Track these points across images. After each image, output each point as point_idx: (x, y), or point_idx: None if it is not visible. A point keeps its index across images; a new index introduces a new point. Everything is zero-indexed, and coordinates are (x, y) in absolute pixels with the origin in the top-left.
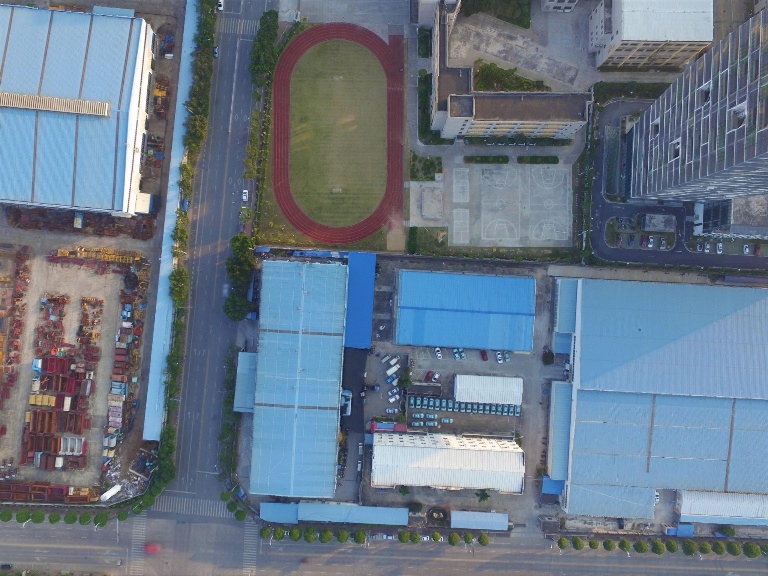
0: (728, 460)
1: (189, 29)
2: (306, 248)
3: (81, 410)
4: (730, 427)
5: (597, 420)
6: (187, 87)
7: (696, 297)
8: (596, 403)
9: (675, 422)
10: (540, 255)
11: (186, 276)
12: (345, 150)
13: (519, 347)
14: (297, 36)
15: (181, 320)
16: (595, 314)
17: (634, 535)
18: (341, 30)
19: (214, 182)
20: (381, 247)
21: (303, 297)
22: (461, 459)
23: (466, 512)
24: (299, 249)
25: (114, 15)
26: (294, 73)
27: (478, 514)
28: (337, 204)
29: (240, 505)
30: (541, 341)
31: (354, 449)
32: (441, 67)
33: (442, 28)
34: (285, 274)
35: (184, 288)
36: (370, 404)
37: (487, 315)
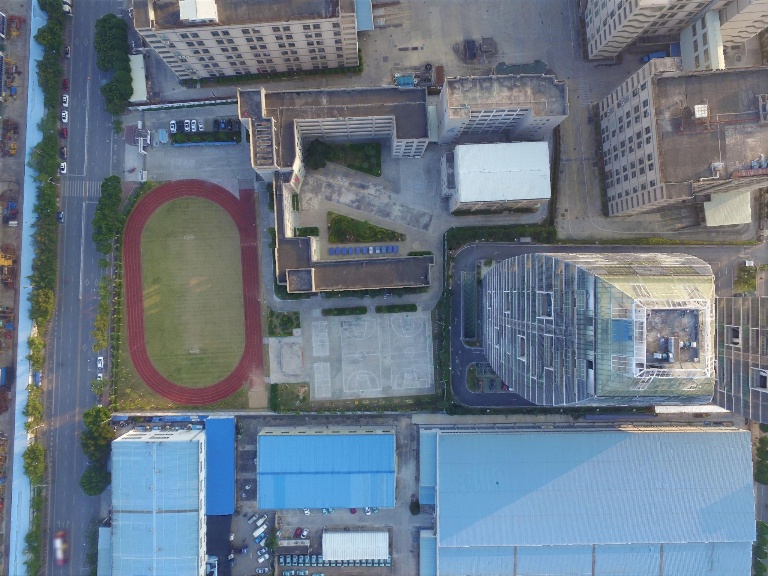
0: None
1: (29, 198)
2: (167, 411)
3: None
4: (591, 571)
5: (460, 574)
6: (30, 259)
7: (552, 446)
8: (458, 558)
9: (537, 570)
10: (403, 404)
11: (41, 453)
12: (201, 309)
13: (381, 504)
14: (145, 196)
15: (42, 494)
16: (453, 470)
17: None
18: (190, 187)
19: (68, 350)
20: (243, 405)
21: (155, 476)
22: None
23: None
24: (158, 415)
25: None
26: (144, 234)
27: None
28: (196, 365)
29: None
30: (408, 489)
31: None
32: (280, 238)
33: (279, 198)
34: (135, 454)
35: (38, 467)
36: (240, 564)
37: (347, 475)
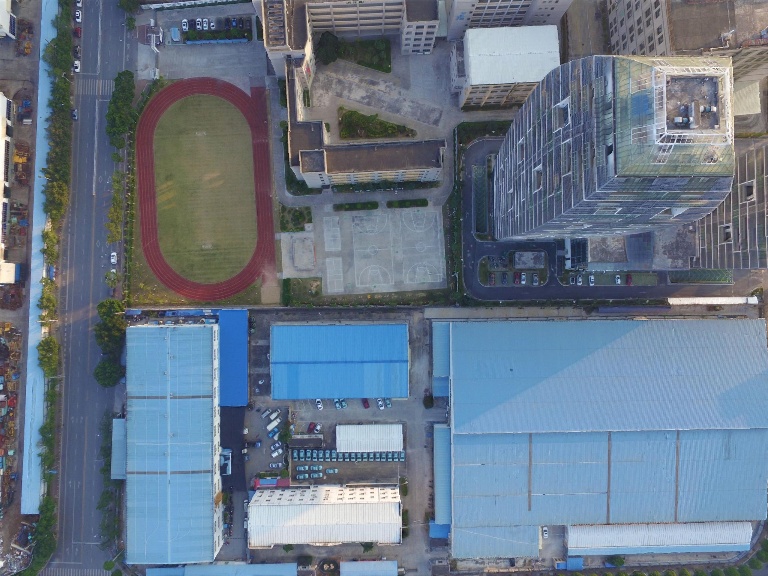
0: (608, 492)
1: (44, 94)
2: (180, 307)
3: None
4: (607, 460)
5: (475, 463)
6: (45, 153)
7: (566, 333)
8: (473, 446)
9: (553, 459)
10: (415, 298)
11: (55, 345)
12: (213, 205)
13: (395, 394)
14: (157, 93)
15: (55, 389)
16: (466, 357)
17: (525, 572)
18: (202, 85)
19: (82, 246)
20: (256, 301)
21: (169, 361)
22: (337, 514)
23: (355, 562)
24: (171, 309)
25: None
26: (157, 131)
27: (367, 563)
28: (208, 260)
29: (128, 572)
30: (422, 384)
31: (240, 506)
32: (292, 122)
33: (291, 83)
34: (149, 339)
35: (52, 358)
36: (254, 460)
37: (361, 365)
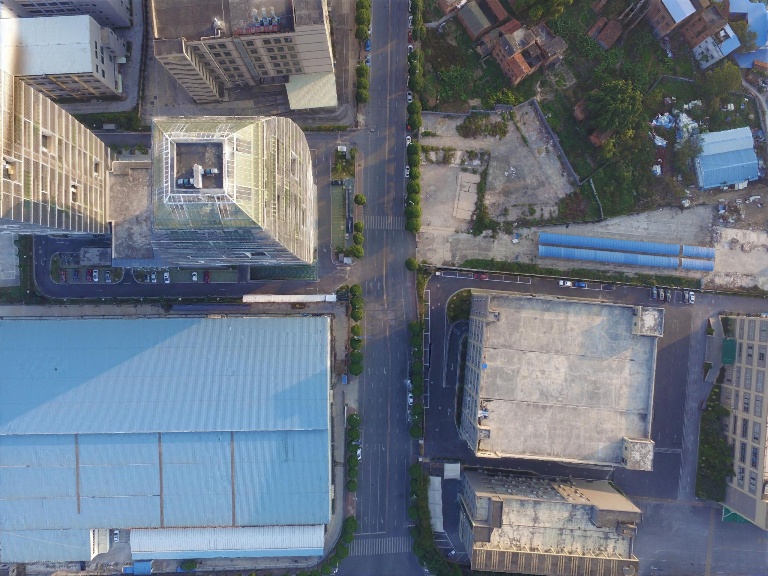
0: (161, 495)
1: None
2: None
3: None
4: (159, 462)
5: (20, 464)
6: None
7: (116, 332)
8: (16, 447)
9: (101, 461)
10: None
11: None
12: None
13: None
14: None
15: None
16: (10, 356)
17: (94, 575)
18: None
19: None
20: None
21: None
22: None
23: None
24: None
25: None
26: None
27: None
28: None
29: None
30: None
31: None
32: None
33: None
34: None
35: None
36: None
37: None
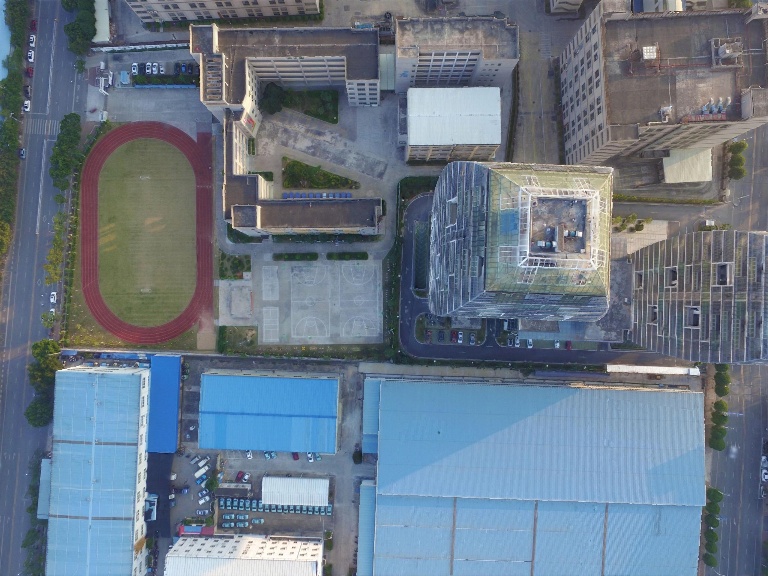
0: (532, 561)
1: None
2: (116, 349)
3: None
4: (533, 529)
5: (398, 524)
6: None
7: (497, 398)
8: (396, 507)
9: (477, 525)
10: (350, 352)
11: None
12: (154, 249)
13: (322, 449)
14: (105, 136)
15: None
16: (394, 417)
17: None
18: (149, 129)
19: (23, 284)
20: (191, 346)
21: (96, 407)
22: (254, 570)
23: None
24: (106, 352)
25: None
26: (102, 173)
27: None
28: (147, 304)
29: None
30: (353, 439)
31: (165, 551)
32: (228, 175)
33: (229, 135)
34: (78, 384)
35: None
36: (181, 505)
37: (289, 418)
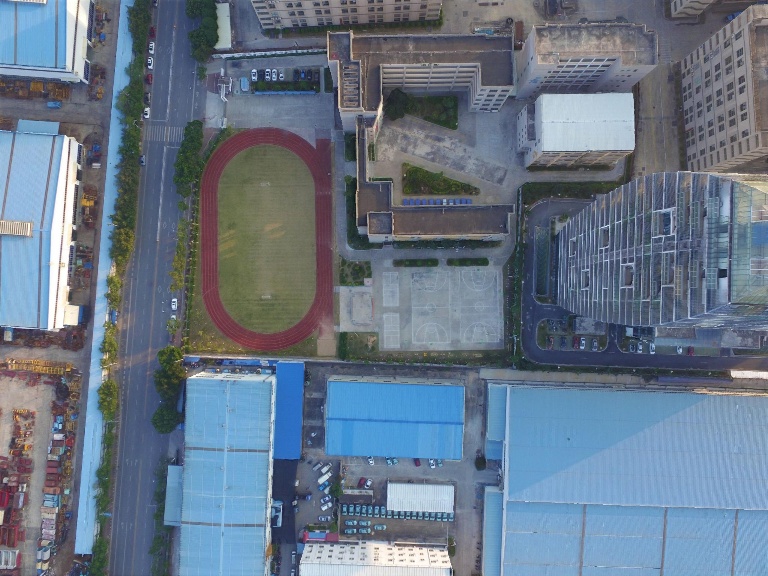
0: (661, 568)
1: (114, 140)
2: (236, 355)
3: (15, 523)
4: (663, 535)
5: (527, 530)
6: (113, 199)
7: (626, 404)
8: (526, 514)
9: (607, 531)
10: (471, 358)
11: (115, 389)
12: (274, 256)
13: (449, 456)
14: (224, 142)
15: (112, 431)
16: (523, 424)
17: None
18: (268, 135)
19: (143, 291)
20: (312, 353)
21: (228, 414)
22: None
23: None
24: (228, 358)
25: (39, 128)
26: (221, 179)
27: None
28: (267, 310)
29: None
30: (474, 445)
31: (288, 557)
32: (361, 182)
33: (361, 142)
34: (209, 391)
35: (112, 402)
36: (303, 512)
37: (416, 425)
